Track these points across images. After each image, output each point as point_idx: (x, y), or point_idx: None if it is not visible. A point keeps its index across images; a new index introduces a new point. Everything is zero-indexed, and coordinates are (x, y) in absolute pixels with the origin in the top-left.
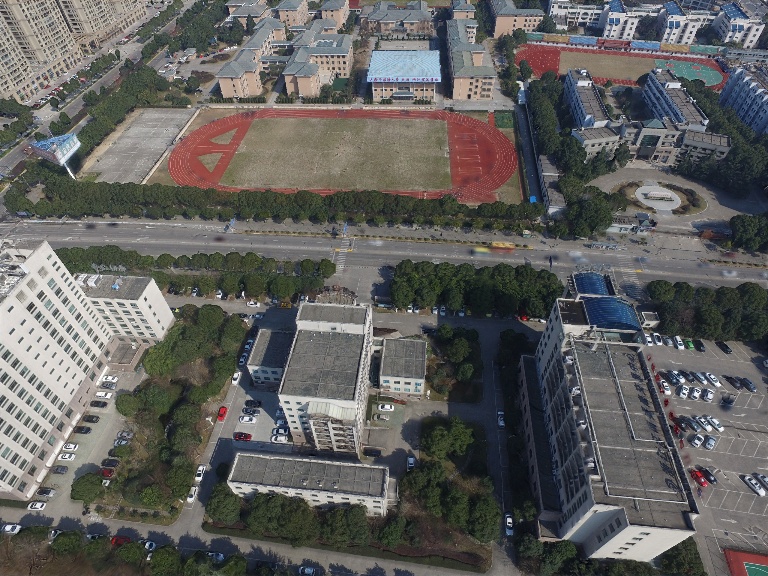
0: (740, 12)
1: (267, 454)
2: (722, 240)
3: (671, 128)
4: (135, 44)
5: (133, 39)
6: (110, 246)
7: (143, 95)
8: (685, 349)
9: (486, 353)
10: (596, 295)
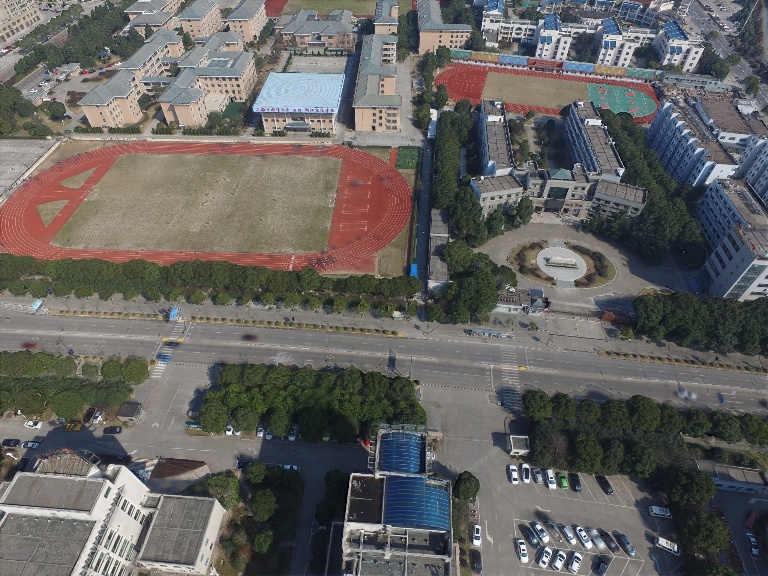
0: (680, 32)
1: None
2: (625, 324)
3: (581, 178)
4: (15, 56)
5: (15, 50)
6: None
7: None
8: (557, 488)
9: (309, 498)
10: (399, 473)
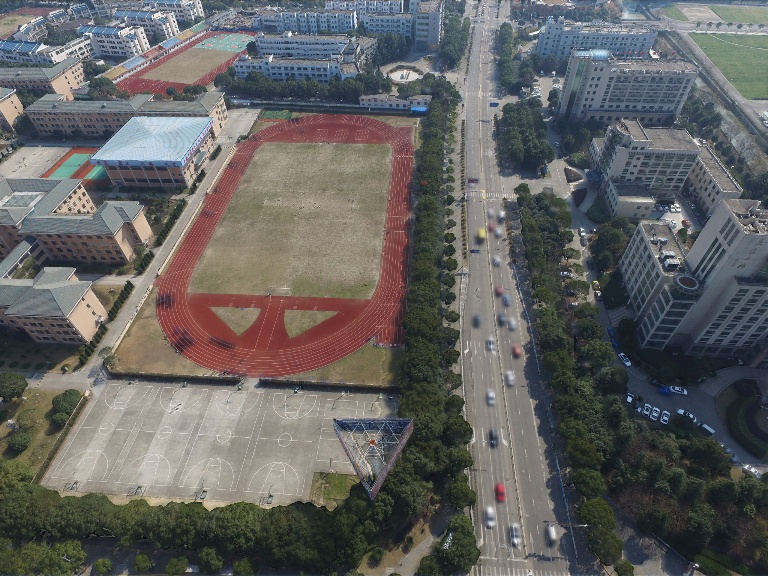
0: None
1: (689, 213)
2: (449, 67)
3: None
4: None
5: None
6: (552, 334)
7: (6, 480)
8: None
9: None
10: None
